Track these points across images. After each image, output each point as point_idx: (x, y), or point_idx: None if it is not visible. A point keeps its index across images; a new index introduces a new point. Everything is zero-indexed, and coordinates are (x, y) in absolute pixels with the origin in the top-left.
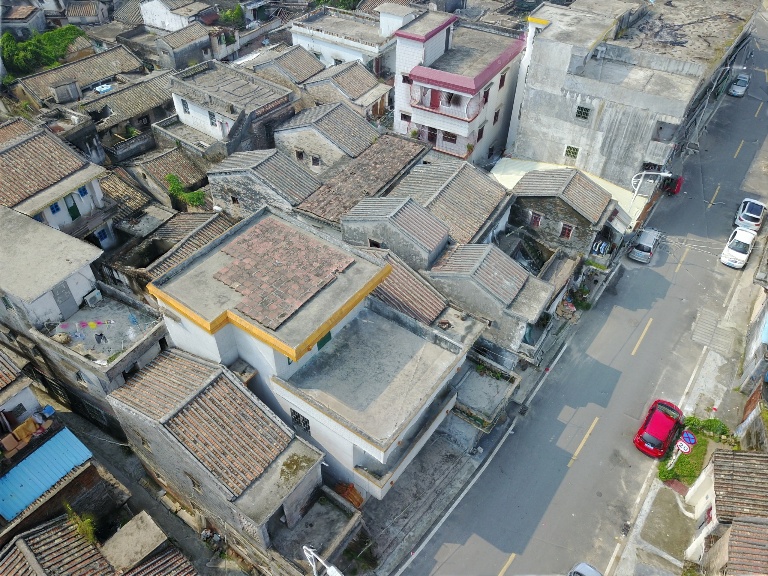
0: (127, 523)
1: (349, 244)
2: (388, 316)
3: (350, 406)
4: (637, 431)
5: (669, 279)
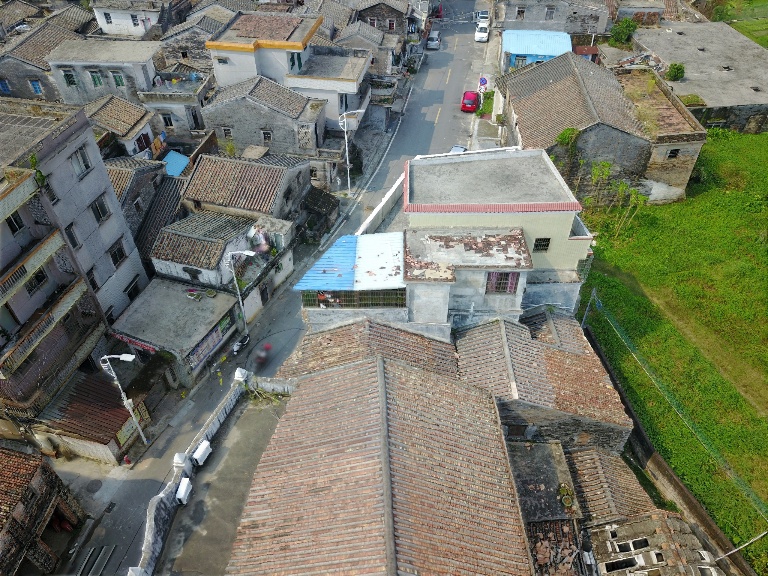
0: (246, 149)
1: (296, 13)
2: (325, 53)
3: None
4: None
5: (452, 53)
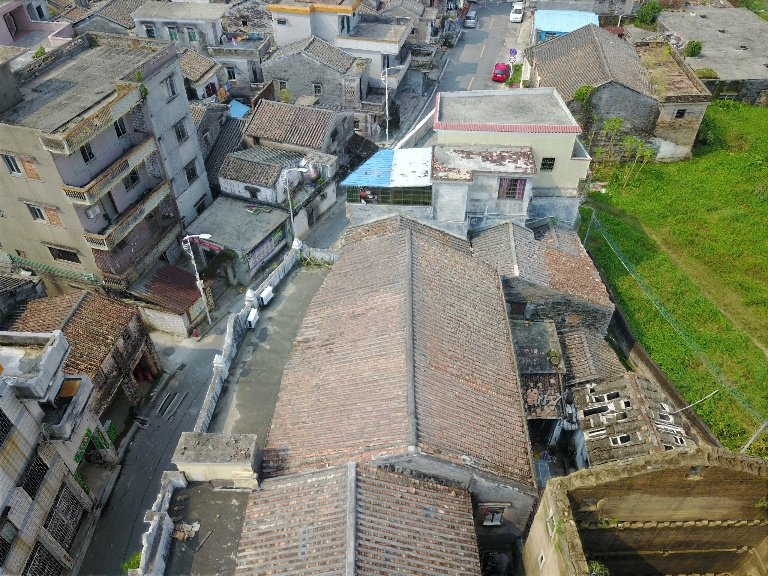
0: (299, 98)
1: None
2: (371, 20)
3: None
4: None
5: (488, 32)
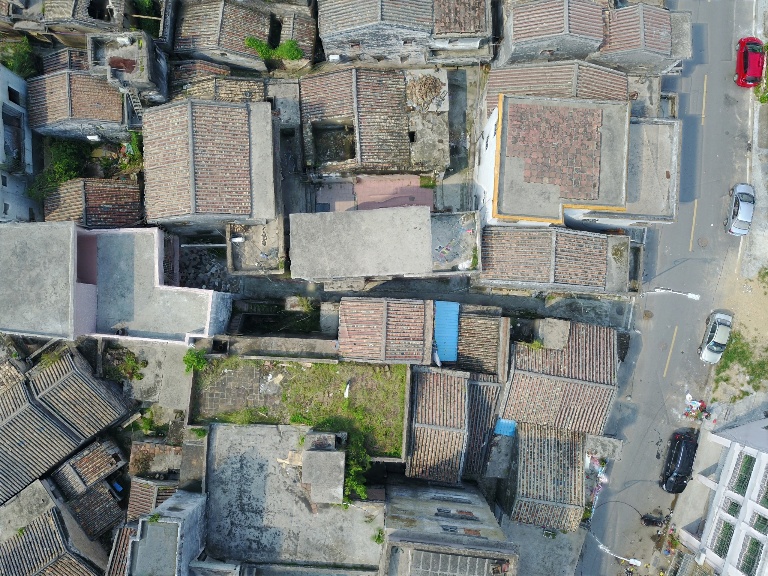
0: (544, 328)
1: (592, 99)
2: None
3: (631, 202)
4: (734, 71)
5: None
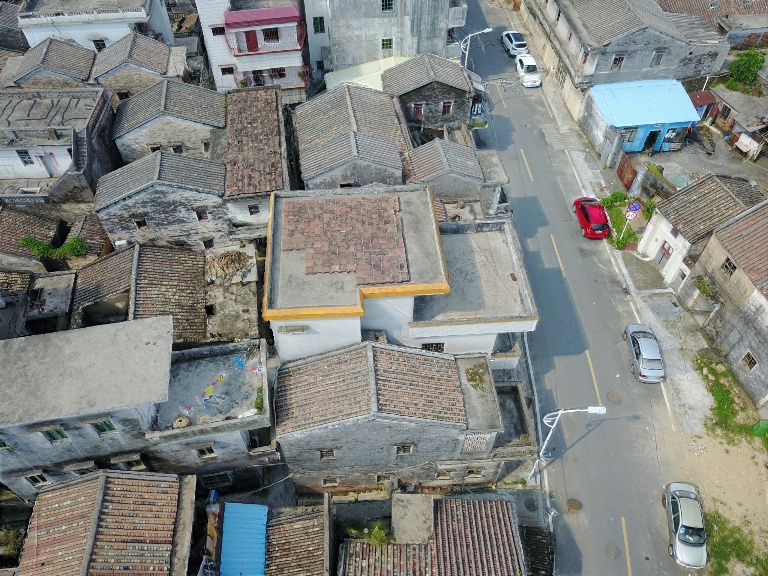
0: (392, 511)
1: (382, 186)
2: None
3: (474, 310)
4: (579, 228)
5: (506, 115)
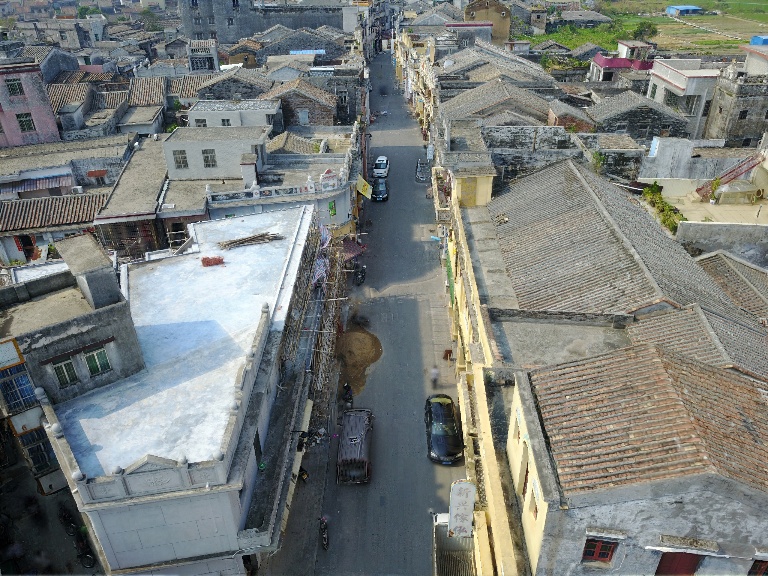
0: None
1: None
2: None
3: None
4: None
5: None
